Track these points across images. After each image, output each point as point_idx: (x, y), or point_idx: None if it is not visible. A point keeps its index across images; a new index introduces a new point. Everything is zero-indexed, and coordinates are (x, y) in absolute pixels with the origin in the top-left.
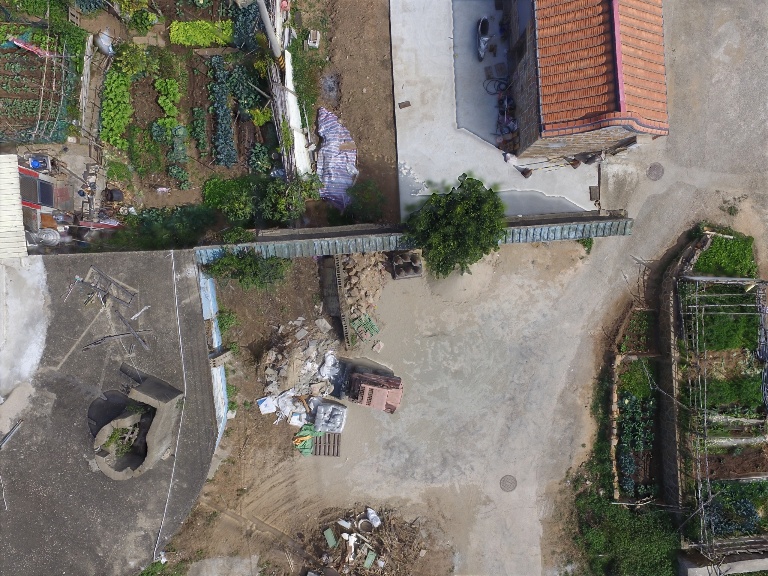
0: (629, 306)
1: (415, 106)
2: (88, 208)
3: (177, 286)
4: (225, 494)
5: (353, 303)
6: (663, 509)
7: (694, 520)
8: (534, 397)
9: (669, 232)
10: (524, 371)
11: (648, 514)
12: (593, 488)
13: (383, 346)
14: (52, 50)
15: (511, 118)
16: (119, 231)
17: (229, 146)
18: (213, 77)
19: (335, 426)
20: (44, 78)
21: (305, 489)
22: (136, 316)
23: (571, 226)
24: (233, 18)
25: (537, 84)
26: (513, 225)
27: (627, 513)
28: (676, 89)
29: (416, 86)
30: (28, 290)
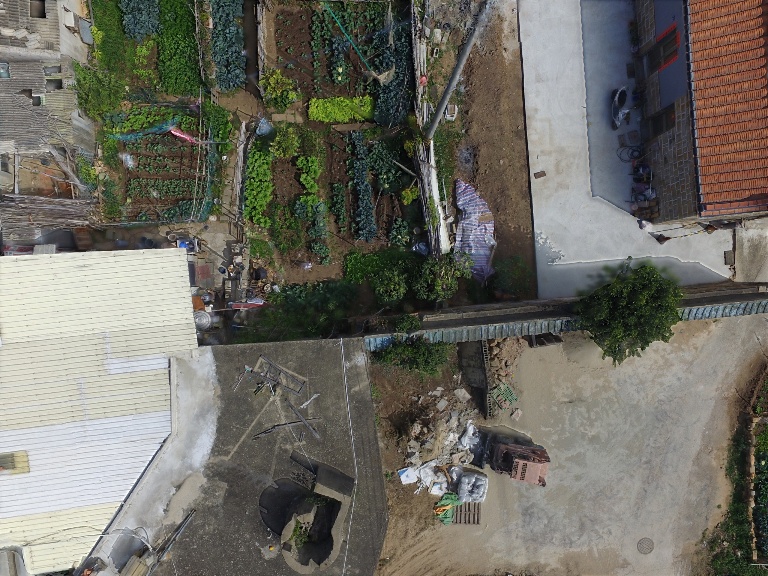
0: (763, 368)
1: (550, 176)
2: (230, 285)
3: (346, 374)
4: None
5: (493, 373)
6: None
7: None
8: (670, 460)
9: None
10: (660, 434)
11: None
12: (730, 548)
13: (521, 414)
14: (192, 130)
15: (647, 186)
16: (266, 310)
17: (370, 221)
18: (351, 152)
19: (478, 496)
20: (198, 164)
21: (446, 557)
22: (306, 404)
23: (734, 305)
24: (371, 94)
25: (695, 164)
26: None
27: (766, 574)
28: None
29: (551, 156)
30: (198, 381)
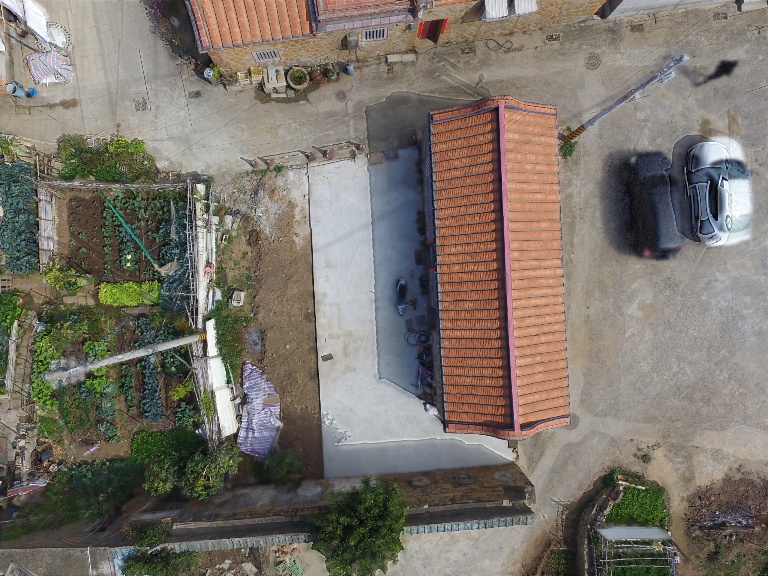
0: (547, 545)
1: (337, 358)
2: (20, 461)
3: None
4: None
5: (278, 549)
6: None
7: None
8: None
9: (585, 477)
10: None
11: None
12: None
13: None
14: None
15: (430, 373)
16: (48, 492)
17: (155, 404)
18: (141, 334)
19: None
20: None
21: None
22: None
23: (473, 522)
24: (159, 279)
25: (442, 381)
26: (419, 516)
27: None
28: (590, 344)
29: (338, 339)
30: None
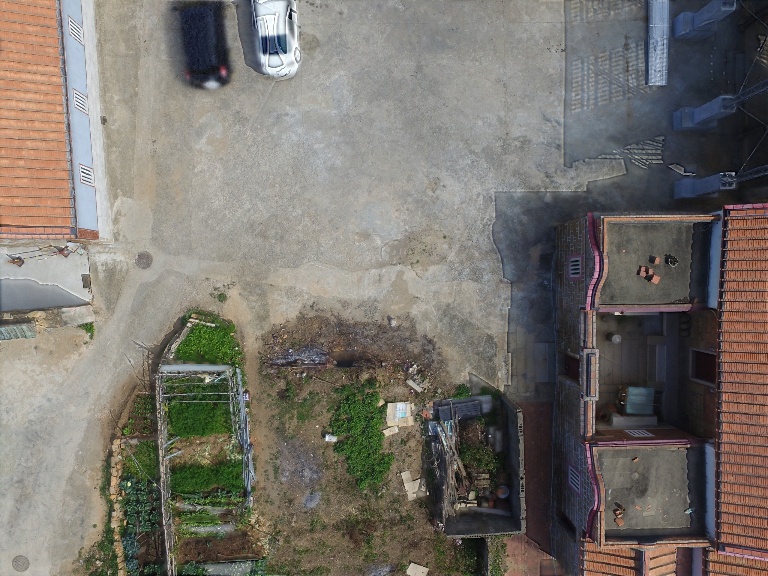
0: (132, 390)
1: None
2: None
3: None
4: None
5: None
6: None
7: None
8: (42, 479)
9: (164, 318)
10: (31, 454)
11: None
12: (104, 567)
13: None
14: None
15: None
16: None
17: None
18: None
19: None
20: None
21: None
22: None
23: None
24: None
25: None
26: None
27: None
28: (158, 179)
29: None
30: None
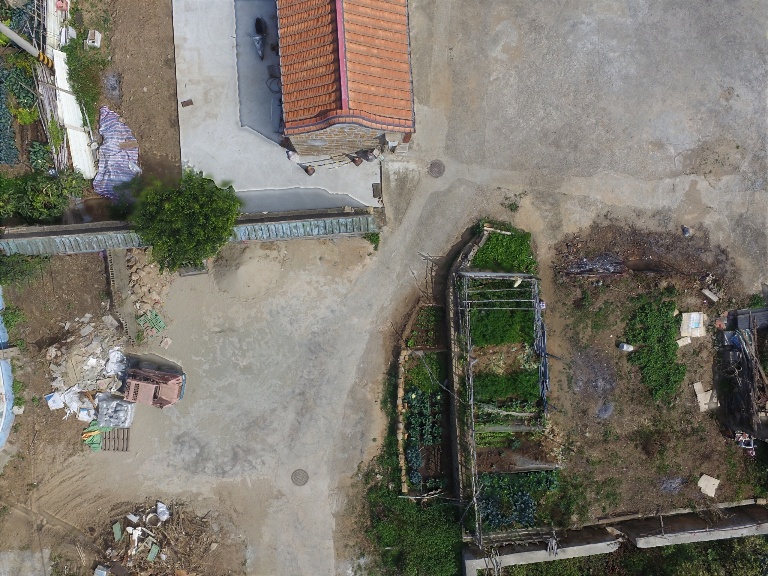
0: (416, 302)
1: (198, 105)
2: None
3: None
4: (15, 489)
5: (137, 300)
6: (447, 502)
7: (470, 513)
8: (324, 392)
9: (453, 228)
10: (313, 366)
11: (433, 507)
12: (384, 482)
13: (171, 342)
14: None
15: None
16: None
17: (8, 145)
18: None
19: (119, 421)
20: None
21: (96, 484)
22: None
23: (311, 223)
24: None
25: (281, 82)
26: (257, 222)
27: (414, 506)
28: (454, 87)
29: (199, 85)
30: None
